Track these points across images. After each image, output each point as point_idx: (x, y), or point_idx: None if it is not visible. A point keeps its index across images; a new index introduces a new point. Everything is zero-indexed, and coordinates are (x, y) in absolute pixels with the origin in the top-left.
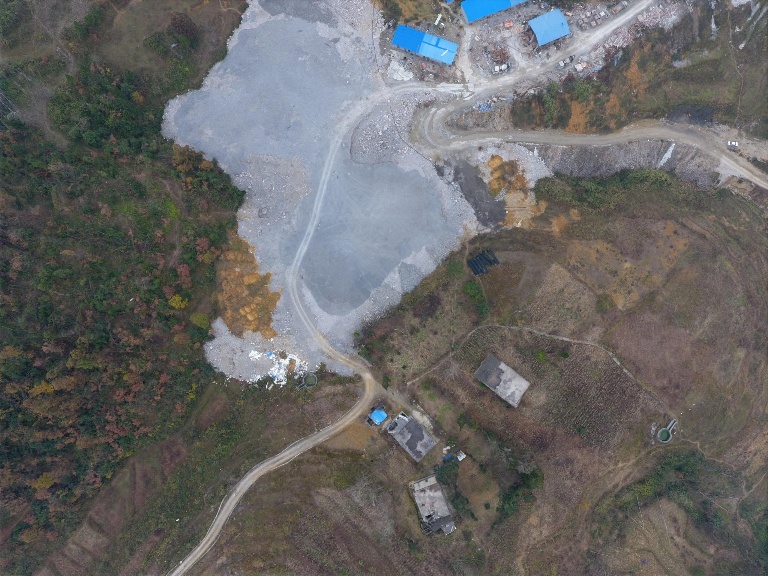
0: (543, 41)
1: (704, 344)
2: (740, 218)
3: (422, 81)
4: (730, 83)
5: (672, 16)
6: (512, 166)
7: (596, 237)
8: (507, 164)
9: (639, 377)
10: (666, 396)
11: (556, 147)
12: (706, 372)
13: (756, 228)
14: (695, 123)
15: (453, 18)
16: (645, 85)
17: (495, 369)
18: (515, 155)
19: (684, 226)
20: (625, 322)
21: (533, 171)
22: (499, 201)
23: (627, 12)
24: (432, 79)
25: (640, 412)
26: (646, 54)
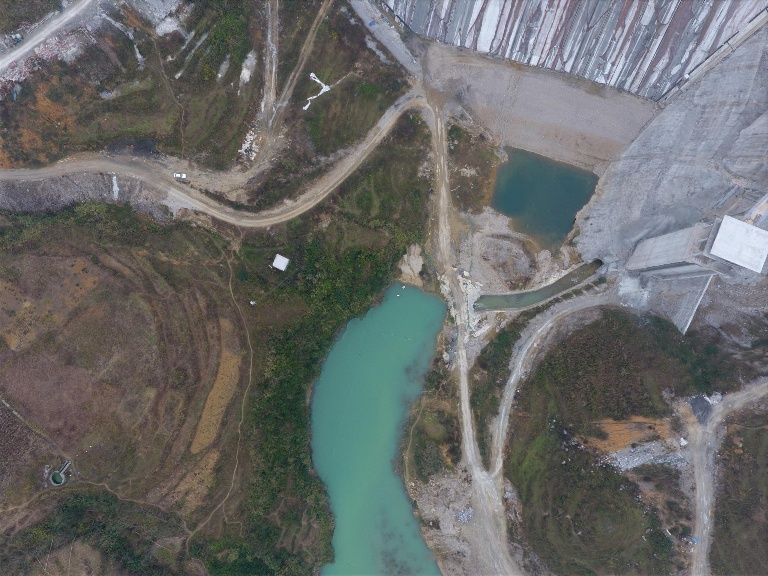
0: None
1: (106, 384)
2: (186, 252)
3: None
4: (168, 114)
5: (71, 48)
6: None
7: None
8: None
9: (29, 419)
10: (60, 438)
11: None
12: (107, 413)
13: (206, 262)
14: (140, 155)
15: None
16: (73, 118)
17: None
18: None
19: (94, 263)
20: (17, 363)
21: None
22: None
23: (25, 45)
24: None
25: (29, 455)
26: (57, 87)
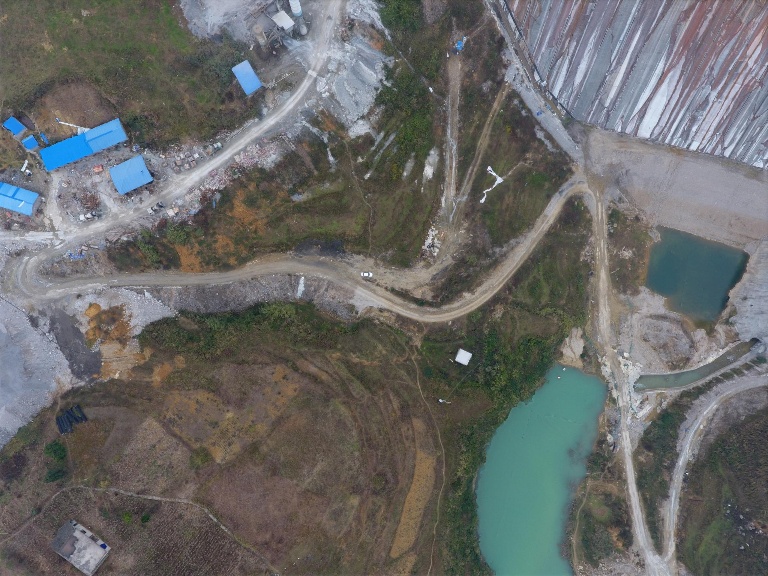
0: (124, 190)
1: (311, 494)
2: (375, 351)
3: (9, 230)
4: (357, 214)
5: (271, 155)
6: (113, 313)
7: (196, 387)
8: (105, 312)
9: (237, 533)
10: (268, 551)
11: (169, 288)
12: (313, 523)
13: (394, 360)
14: (326, 254)
15: (40, 164)
16: (264, 220)
17: (69, 537)
18: (122, 299)
19: (294, 370)
20: (223, 476)
21: (140, 316)
22: (95, 352)
23: (224, 152)
24: (19, 228)
25: (238, 570)
26: (253, 192)
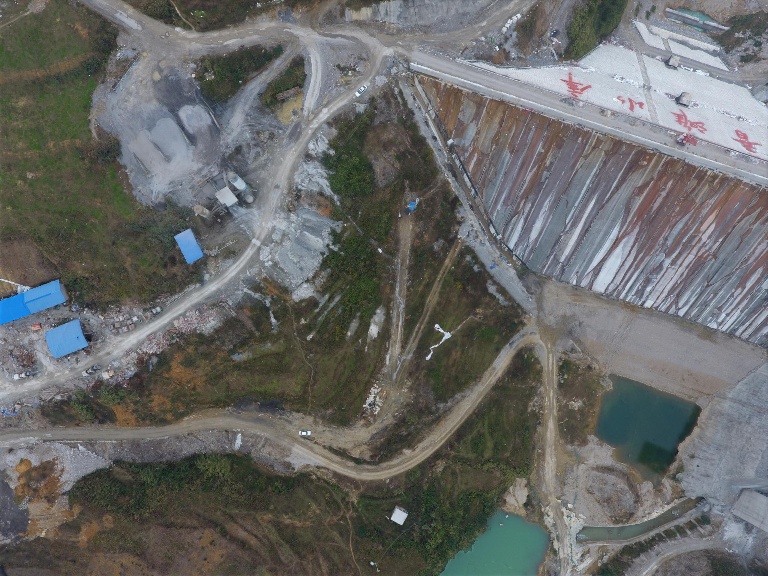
0: (58, 354)
1: None
2: (308, 511)
3: None
4: (298, 374)
5: (211, 321)
6: (44, 469)
7: (121, 550)
8: (35, 469)
9: None
10: None
11: (103, 443)
12: None
13: (327, 520)
14: (265, 411)
15: None
16: (202, 378)
17: None
18: (55, 453)
19: (222, 536)
20: None
21: (72, 471)
22: (23, 509)
23: (163, 316)
24: None
25: None
26: (192, 354)
